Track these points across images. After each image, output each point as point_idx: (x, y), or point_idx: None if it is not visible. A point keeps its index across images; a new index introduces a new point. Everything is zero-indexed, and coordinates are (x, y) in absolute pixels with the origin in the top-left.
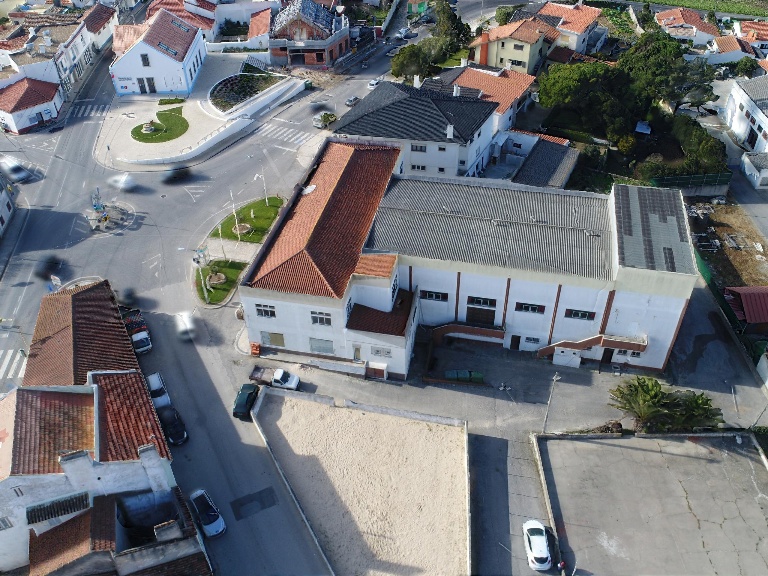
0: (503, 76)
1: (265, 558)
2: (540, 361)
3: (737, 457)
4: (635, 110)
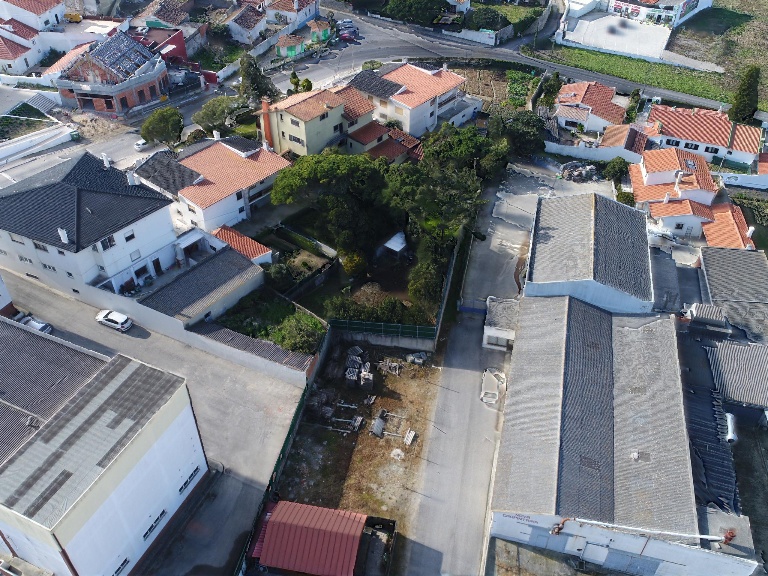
0: (251, 158)
1: None
2: None
3: None
4: (396, 218)
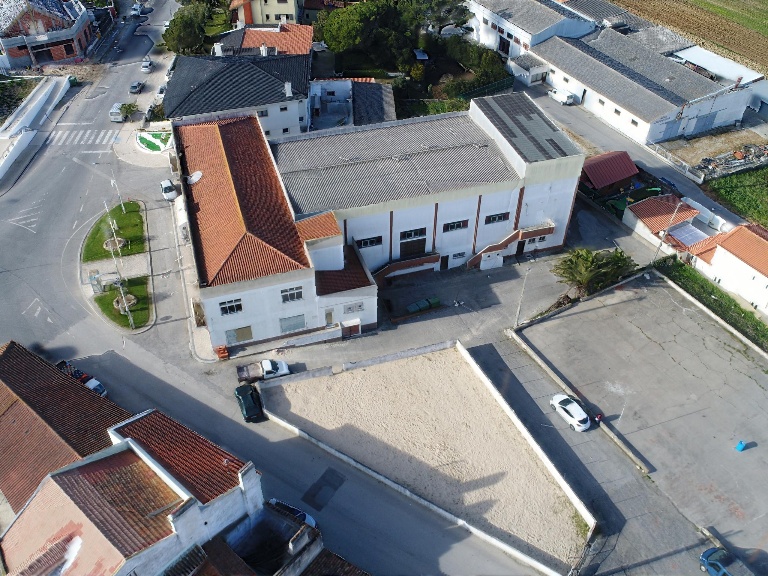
0: (284, 31)
1: (370, 530)
2: (470, 272)
3: (654, 289)
4: None
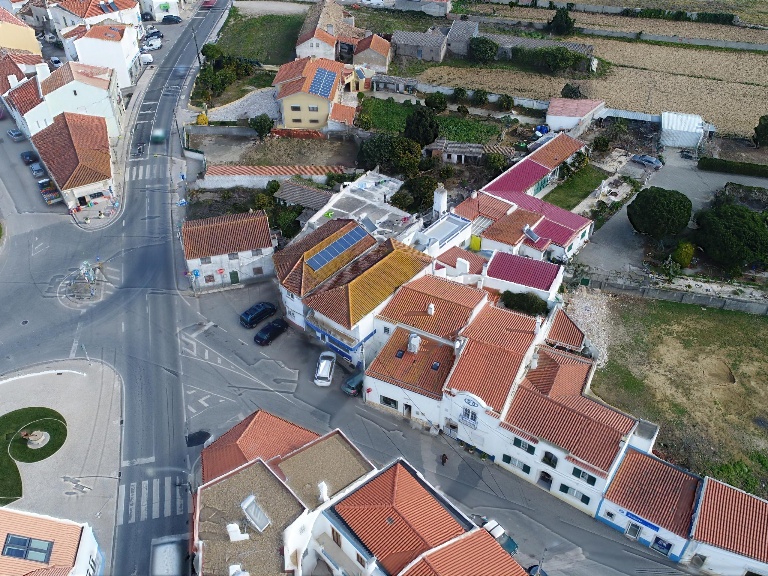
0: None
1: None
2: None
3: None
4: None
